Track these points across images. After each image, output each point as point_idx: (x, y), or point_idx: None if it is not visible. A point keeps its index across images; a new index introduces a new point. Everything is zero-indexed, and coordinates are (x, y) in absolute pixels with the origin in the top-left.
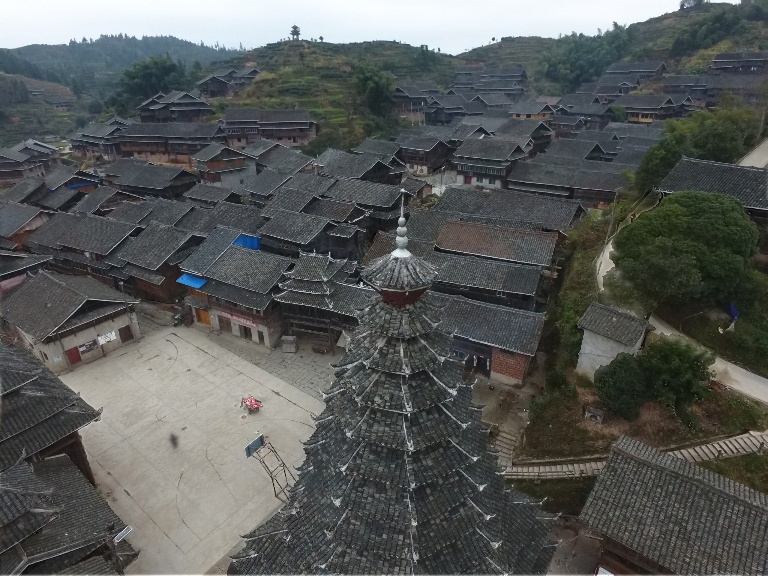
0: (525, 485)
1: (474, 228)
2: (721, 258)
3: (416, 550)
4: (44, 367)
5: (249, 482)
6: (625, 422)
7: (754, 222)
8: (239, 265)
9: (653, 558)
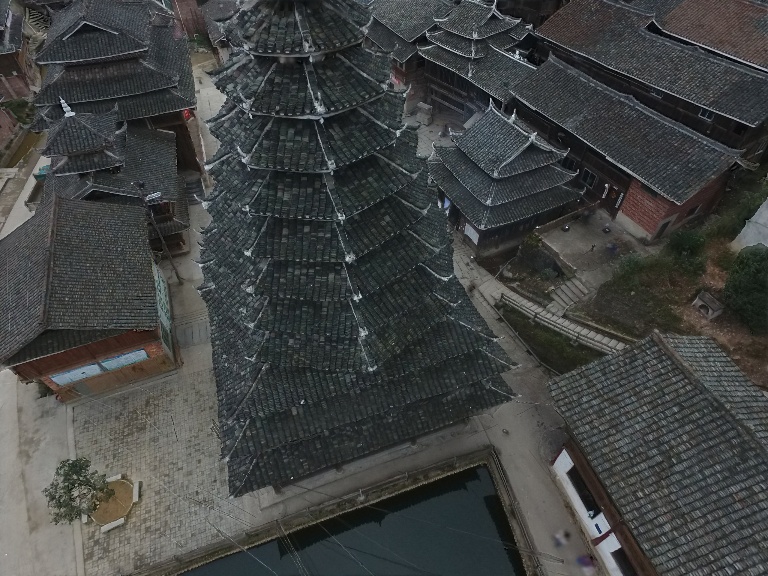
0: (557, 339)
1: (737, 6)
2: None
3: (250, 283)
4: (187, 56)
5: None
6: (750, 334)
7: None
8: (401, 3)
9: (596, 466)
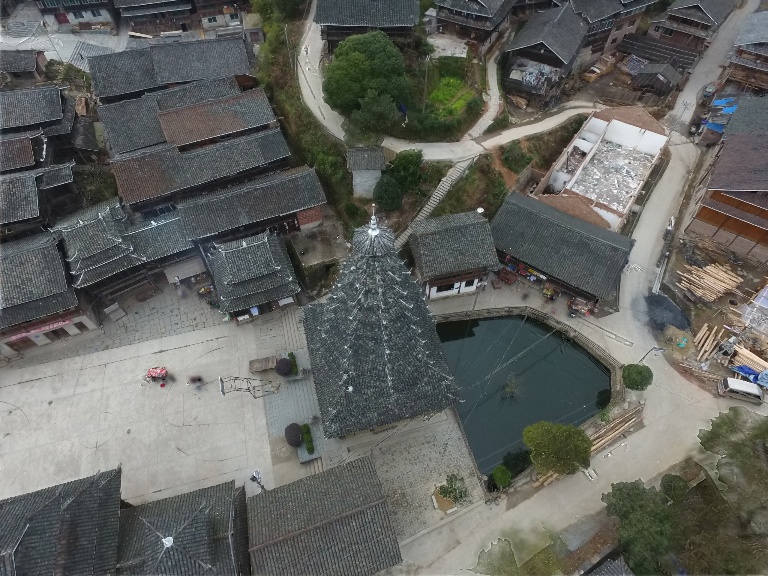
0: None
1: (191, 111)
2: (395, 84)
3: (423, 340)
4: None
5: (229, 409)
6: (395, 211)
7: (398, 48)
8: None
9: (457, 270)
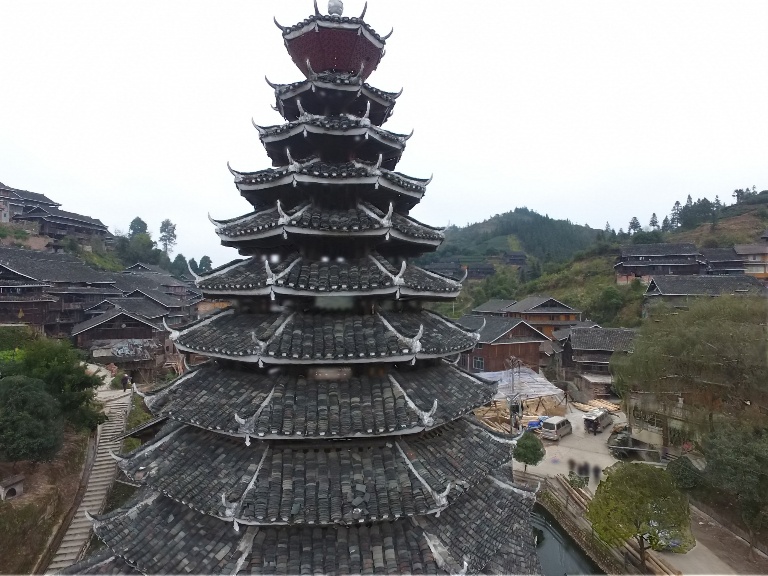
0: None
1: None
2: None
3: None
4: None
5: None
6: (36, 476)
7: None
8: None
9: None
